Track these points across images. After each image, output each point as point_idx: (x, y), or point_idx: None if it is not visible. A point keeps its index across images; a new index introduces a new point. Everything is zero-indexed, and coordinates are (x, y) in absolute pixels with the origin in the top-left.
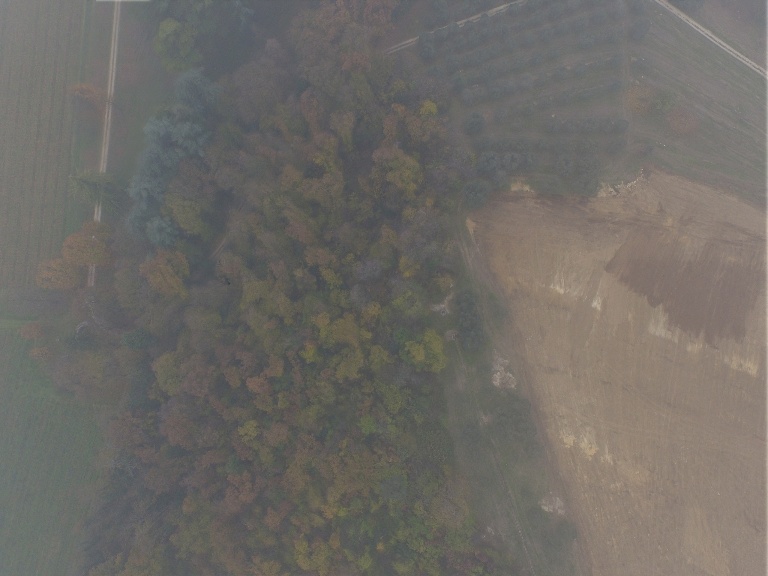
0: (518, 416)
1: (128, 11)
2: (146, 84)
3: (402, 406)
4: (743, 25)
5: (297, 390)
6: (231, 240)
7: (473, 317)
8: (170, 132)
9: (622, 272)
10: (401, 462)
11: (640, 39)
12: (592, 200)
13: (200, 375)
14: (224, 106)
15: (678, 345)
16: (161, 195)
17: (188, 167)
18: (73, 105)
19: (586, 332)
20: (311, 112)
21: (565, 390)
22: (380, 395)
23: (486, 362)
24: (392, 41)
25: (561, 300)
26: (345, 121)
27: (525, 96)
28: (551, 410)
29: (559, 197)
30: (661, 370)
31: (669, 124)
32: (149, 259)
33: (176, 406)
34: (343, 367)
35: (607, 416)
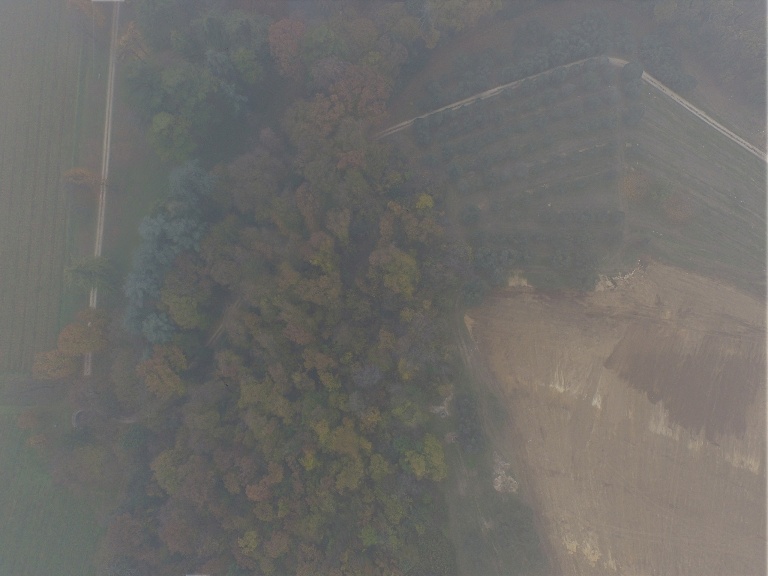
0: (520, 525)
1: (121, 91)
2: (140, 167)
3: (403, 515)
4: (736, 104)
5: (297, 496)
6: (228, 340)
7: (473, 423)
8: (165, 230)
9: (621, 368)
10: (403, 575)
11: (634, 124)
12: (590, 294)
13: (199, 479)
14: (219, 194)
15: (679, 443)
16: (157, 291)
17: (184, 263)
18: (67, 189)
19: (587, 432)
20: (307, 207)
21: (567, 494)
22: (381, 504)
23: (487, 465)
24: (387, 123)
25: (561, 399)
26: (341, 221)
27: (521, 184)
28: (553, 515)
29: (557, 292)
30: (663, 470)
31: (665, 212)
32: (146, 358)
33: (175, 511)
34: (343, 477)
35: (609, 520)
